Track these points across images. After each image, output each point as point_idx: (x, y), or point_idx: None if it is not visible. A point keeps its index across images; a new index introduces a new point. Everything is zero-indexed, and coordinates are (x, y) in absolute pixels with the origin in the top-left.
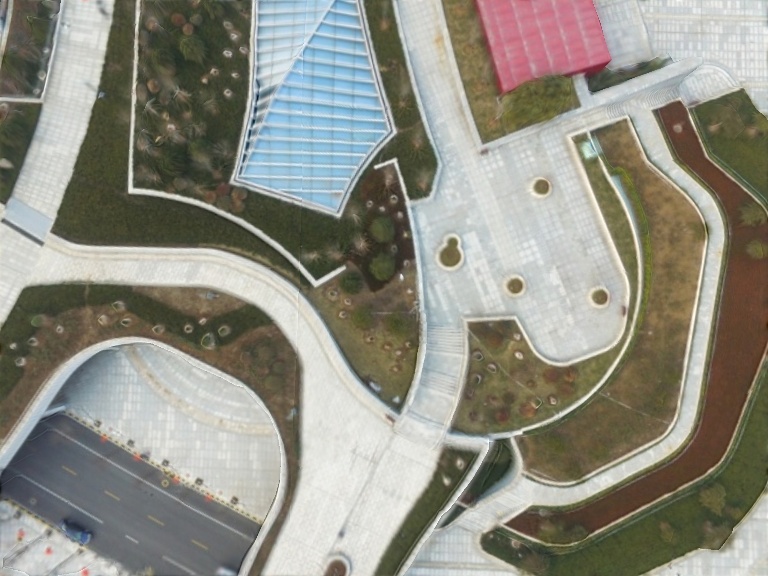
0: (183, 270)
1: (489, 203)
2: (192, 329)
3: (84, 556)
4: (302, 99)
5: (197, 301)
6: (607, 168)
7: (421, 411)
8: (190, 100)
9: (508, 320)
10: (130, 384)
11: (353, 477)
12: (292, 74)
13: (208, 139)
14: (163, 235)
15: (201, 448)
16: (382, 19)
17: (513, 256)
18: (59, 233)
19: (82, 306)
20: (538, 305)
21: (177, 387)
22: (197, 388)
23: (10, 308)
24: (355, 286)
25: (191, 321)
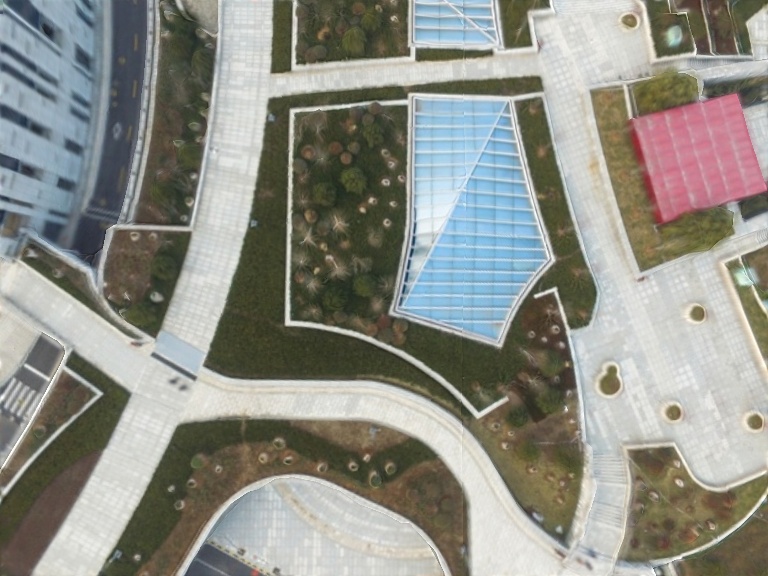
0: (342, 403)
1: (645, 329)
2: (358, 467)
3: None
4: (466, 232)
5: (358, 435)
6: (758, 293)
7: (590, 545)
8: (349, 230)
9: (667, 447)
10: (274, 510)
11: None
12: (457, 207)
13: (372, 273)
14: (321, 367)
15: (349, 574)
16: (539, 146)
17: (669, 382)
18: (212, 367)
19: (239, 443)
20: (694, 430)
21: (323, 512)
22: (344, 512)
23: (164, 447)
24: (522, 420)
25: (355, 458)
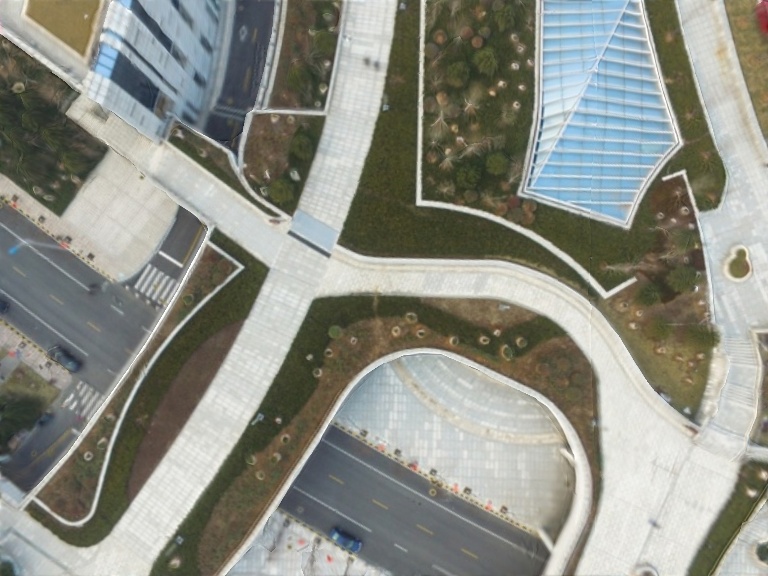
0: (471, 281)
1: None
2: (489, 340)
3: (357, 565)
4: (598, 111)
5: (487, 312)
6: None
7: (721, 423)
8: (479, 112)
9: None
10: (395, 394)
11: (655, 488)
12: (589, 87)
13: (504, 152)
14: (450, 247)
15: (468, 458)
16: (667, 31)
17: None
18: (346, 245)
19: (372, 317)
20: None
21: (443, 397)
22: (463, 398)
23: (301, 319)
24: (653, 298)
25: (485, 332)
